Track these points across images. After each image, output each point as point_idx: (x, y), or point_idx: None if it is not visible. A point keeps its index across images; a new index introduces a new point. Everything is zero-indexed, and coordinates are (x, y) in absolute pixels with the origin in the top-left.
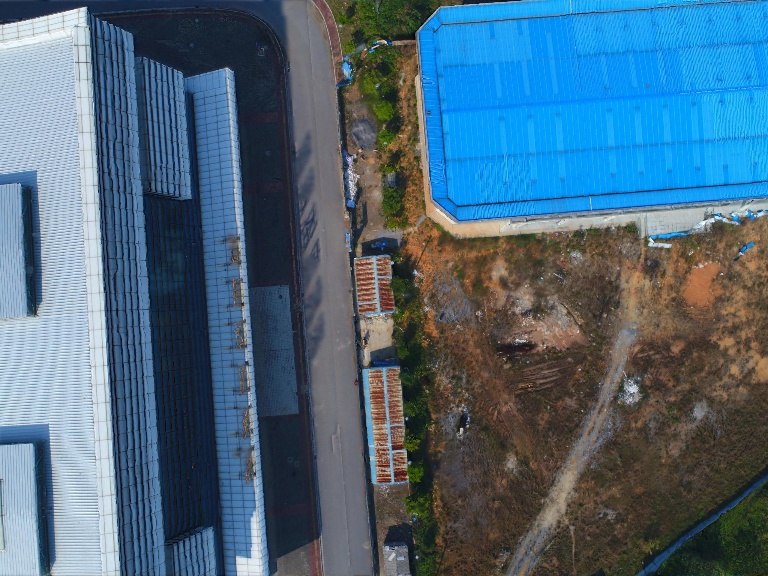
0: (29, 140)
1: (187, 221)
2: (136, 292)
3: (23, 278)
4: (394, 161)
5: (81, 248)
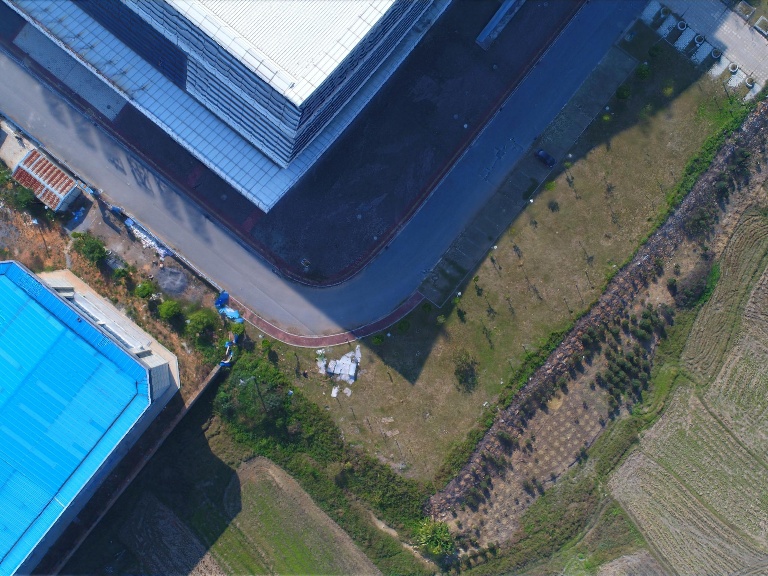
0: None
1: (179, 73)
2: None
3: None
4: (130, 283)
5: None
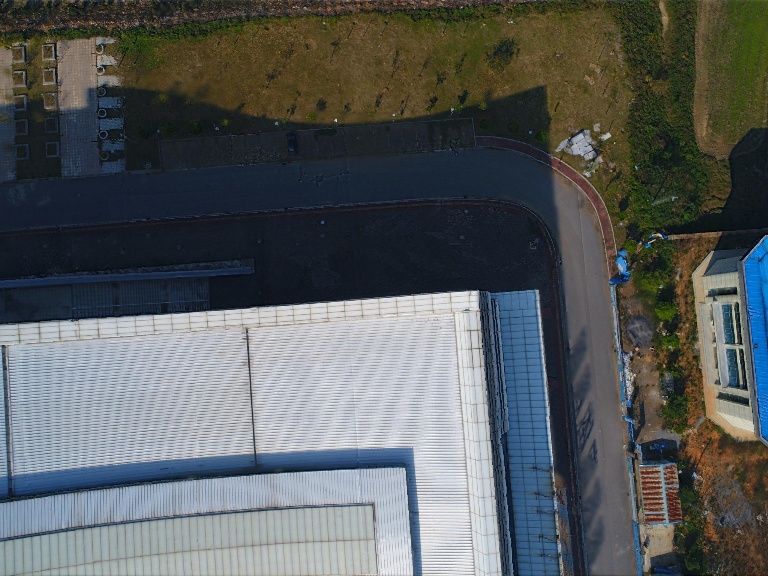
0: (404, 416)
1: None
2: (508, 569)
3: (412, 568)
4: (672, 360)
5: (467, 535)
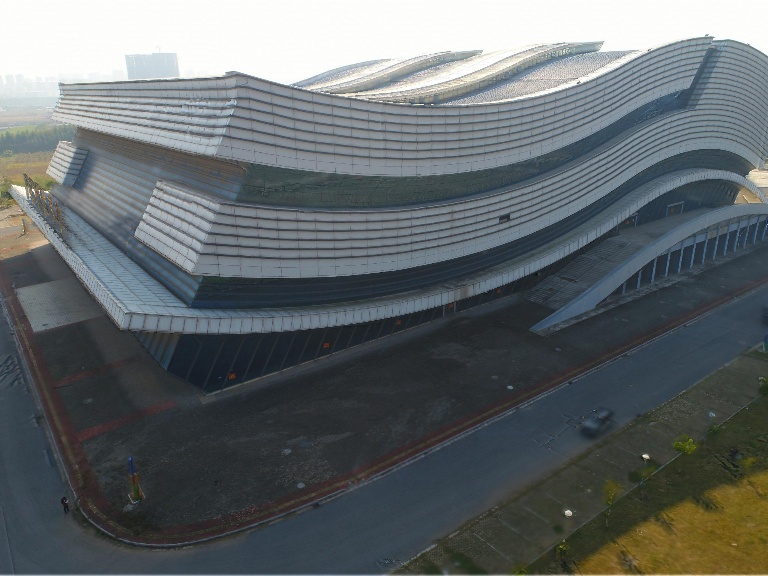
0: None
1: None
2: None
3: None
4: None
5: None
